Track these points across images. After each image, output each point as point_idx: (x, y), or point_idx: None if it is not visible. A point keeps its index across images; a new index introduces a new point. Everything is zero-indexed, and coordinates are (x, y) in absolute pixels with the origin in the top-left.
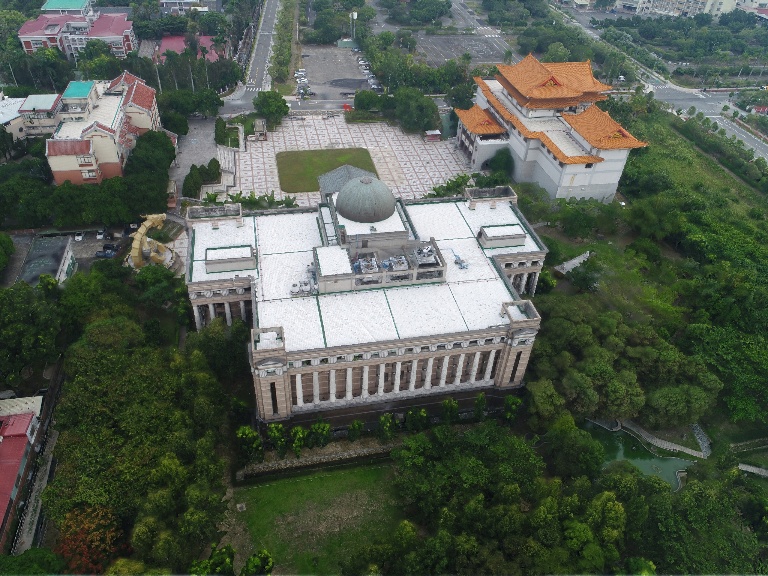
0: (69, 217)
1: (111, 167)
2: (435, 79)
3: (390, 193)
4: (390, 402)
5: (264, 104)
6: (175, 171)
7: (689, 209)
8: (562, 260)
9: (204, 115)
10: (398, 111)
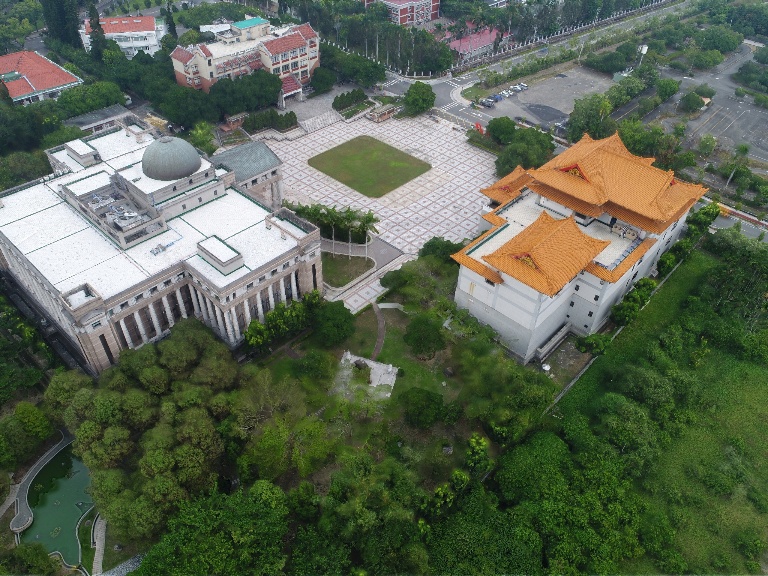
0: (156, 103)
1: (205, 82)
2: None
3: (175, 161)
4: (42, 310)
5: (409, 93)
6: None
7: (603, 434)
8: (364, 353)
9: (358, 83)
10: None
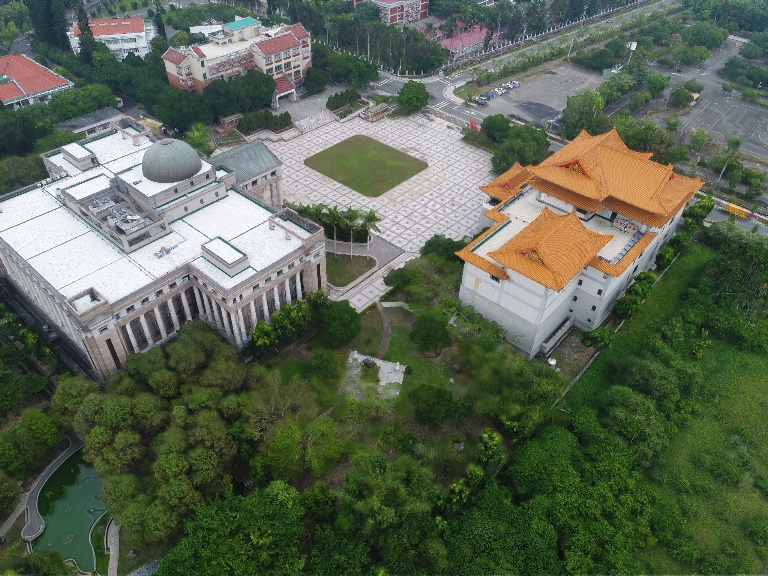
0: (149, 105)
1: (199, 83)
2: None
3: (176, 163)
4: (44, 315)
5: (402, 92)
6: None
7: (612, 427)
8: (371, 352)
9: (351, 82)
10: (501, 146)
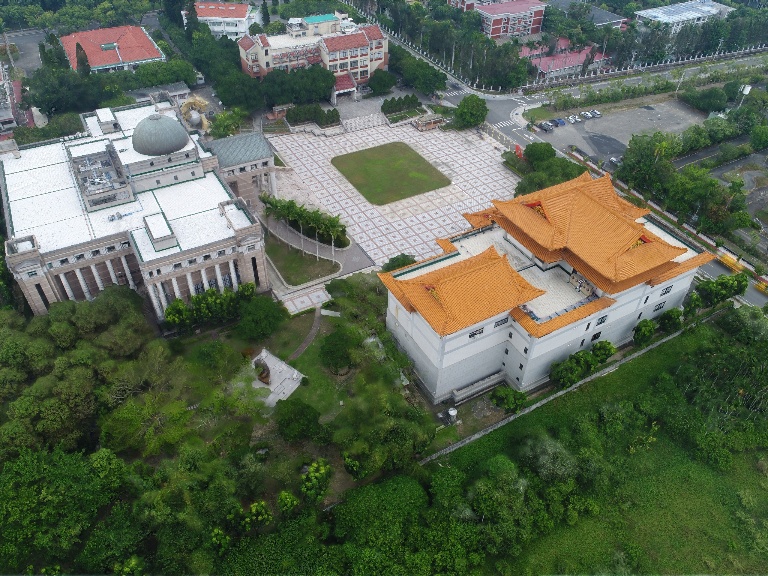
0: (217, 85)
1: (262, 70)
2: (670, 189)
3: (157, 138)
4: None
5: None
6: (327, 107)
7: None
8: None
9: (416, 89)
10: None
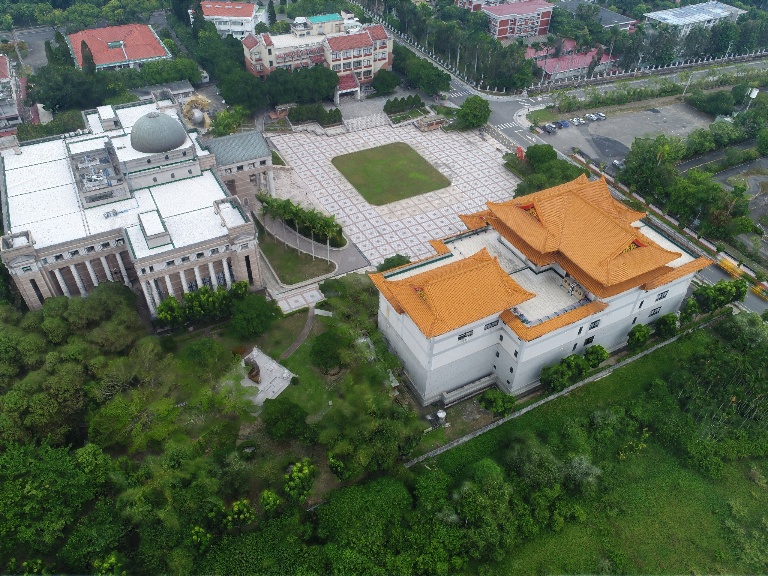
0: (221, 83)
1: None
2: (672, 193)
3: (154, 136)
4: None
5: None
6: (330, 107)
7: None
8: None
9: (419, 89)
10: None
